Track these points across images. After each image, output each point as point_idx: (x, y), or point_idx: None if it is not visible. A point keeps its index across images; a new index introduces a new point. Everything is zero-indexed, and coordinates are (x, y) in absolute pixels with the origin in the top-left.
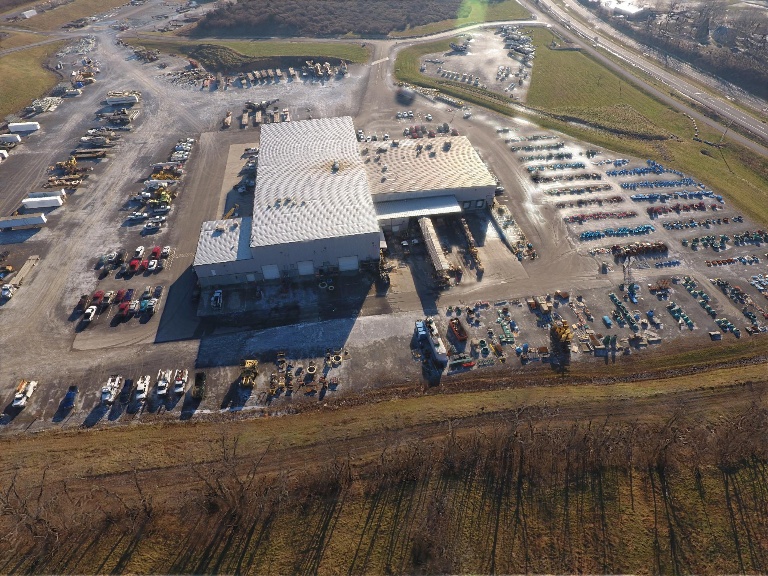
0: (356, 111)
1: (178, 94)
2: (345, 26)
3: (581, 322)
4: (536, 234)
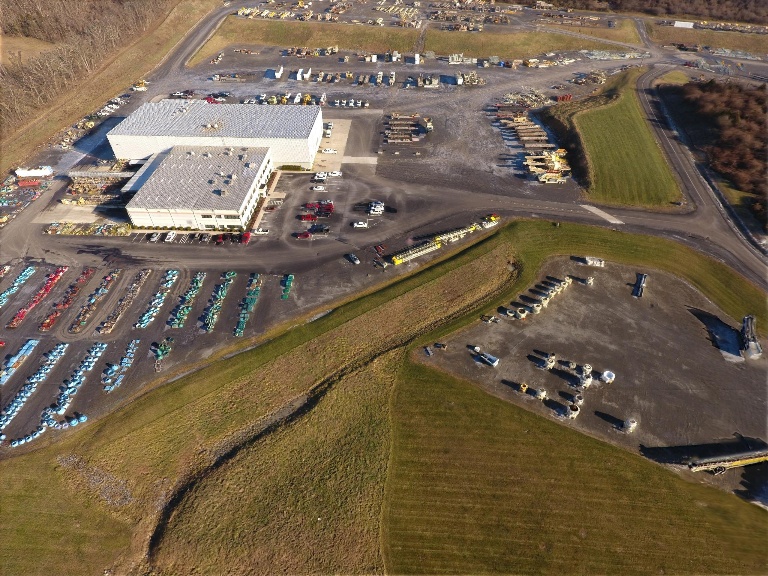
0: (403, 179)
1: (478, 98)
2: (764, 184)
3: None
4: (69, 242)
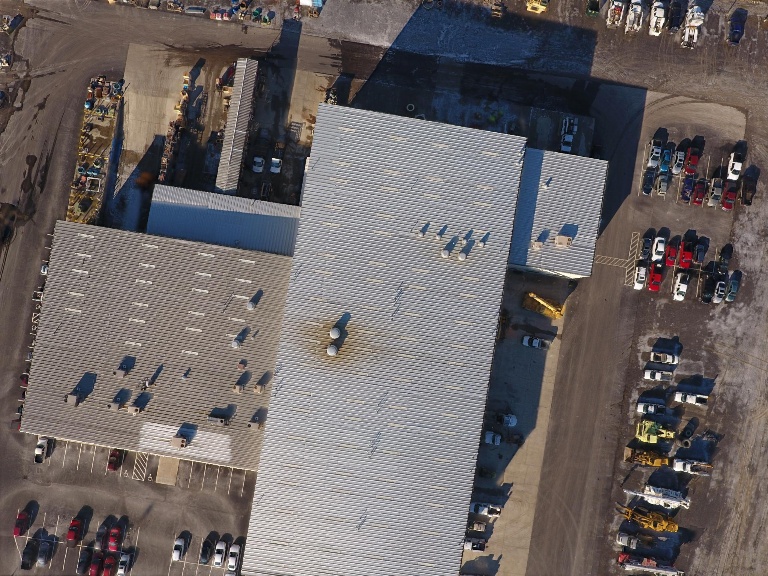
0: None
1: None
2: None
3: None
4: (62, 131)
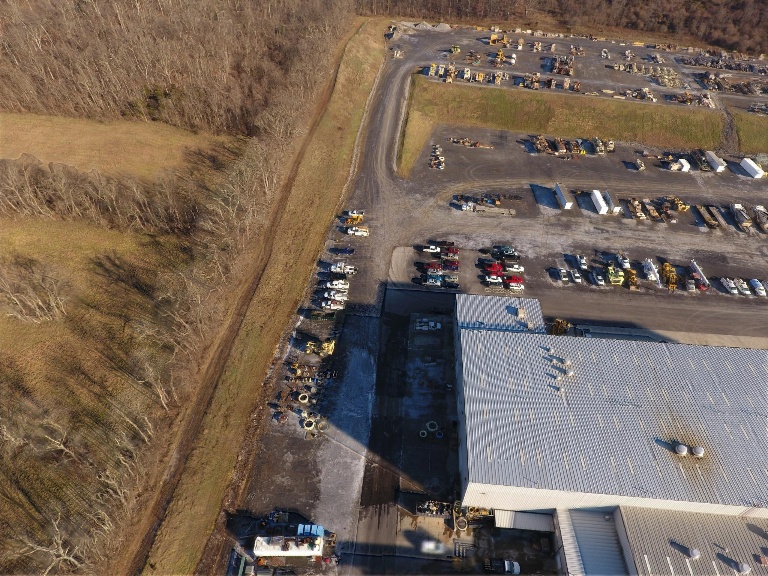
0: None
1: None
2: None
3: None
4: None
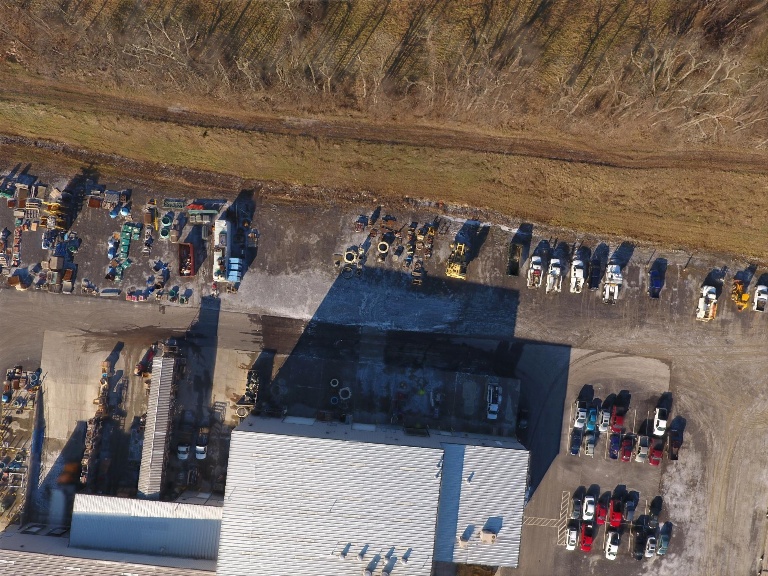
0: None
1: None
2: None
3: (21, 231)
4: None
